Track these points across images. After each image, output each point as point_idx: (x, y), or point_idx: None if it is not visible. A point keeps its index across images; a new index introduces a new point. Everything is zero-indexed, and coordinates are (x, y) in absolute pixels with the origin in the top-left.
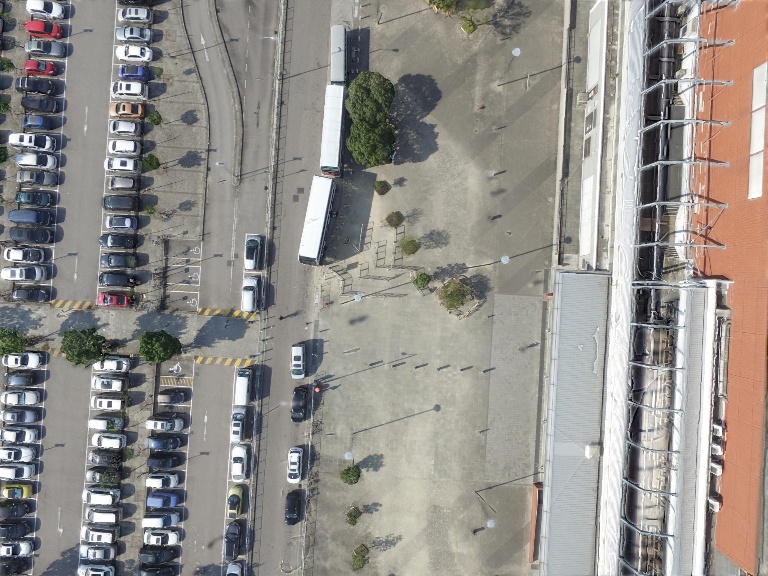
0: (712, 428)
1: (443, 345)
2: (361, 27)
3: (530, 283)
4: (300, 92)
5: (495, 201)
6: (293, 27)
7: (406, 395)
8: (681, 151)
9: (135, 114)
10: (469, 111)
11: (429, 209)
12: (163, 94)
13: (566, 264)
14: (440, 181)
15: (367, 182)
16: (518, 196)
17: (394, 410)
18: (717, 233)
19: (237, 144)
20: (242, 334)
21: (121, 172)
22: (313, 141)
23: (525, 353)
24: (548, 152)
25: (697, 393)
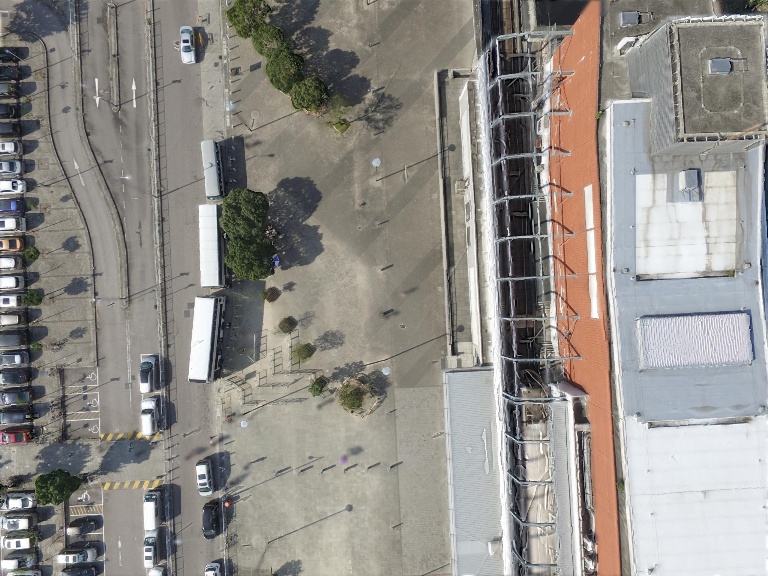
0: (582, 542)
1: (348, 445)
2: (234, 136)
3: (428, 374)
4: (180, 207)
5: (385, 296)
6: (166, 142)
7: (317, 498)
8: (547, 247)
9: (14, 249)
10: (351, 209)
11: (321, 311)
12: (41, 224)
13: (461, 353)
14: (329, 282)
15: (257, 290)
16: (408, 289)
17: (307, 514)
18: (575, 341)
19: (122, 266)
20: (147, 456)
21: (7, 308)
22: (198, 255)
23: (430, 444)
24: (433, 242)
25: (567, 506)
